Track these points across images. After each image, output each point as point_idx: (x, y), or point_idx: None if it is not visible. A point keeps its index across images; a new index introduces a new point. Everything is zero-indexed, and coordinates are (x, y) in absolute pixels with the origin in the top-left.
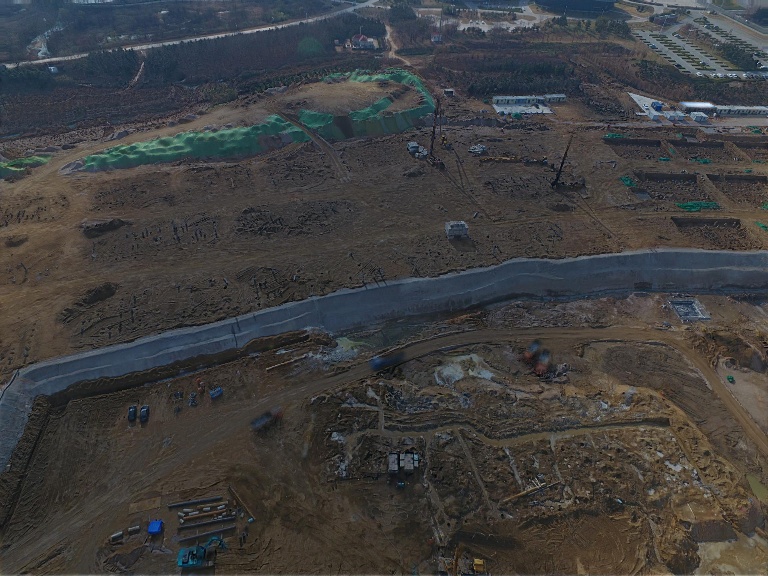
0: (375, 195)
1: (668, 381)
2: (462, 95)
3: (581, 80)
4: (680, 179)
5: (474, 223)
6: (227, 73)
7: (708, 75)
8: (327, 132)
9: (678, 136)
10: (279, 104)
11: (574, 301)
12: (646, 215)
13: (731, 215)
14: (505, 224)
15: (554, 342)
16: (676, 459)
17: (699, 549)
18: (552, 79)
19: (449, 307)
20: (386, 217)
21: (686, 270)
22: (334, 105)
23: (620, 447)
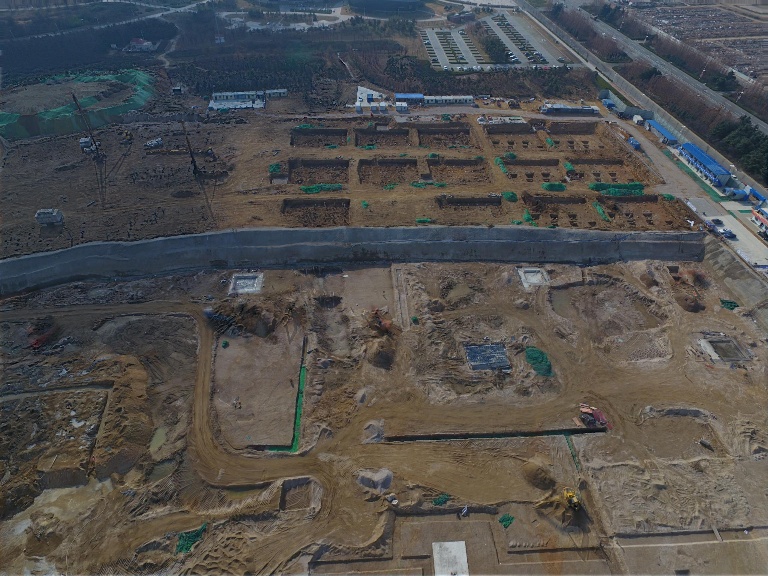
0: (7, 188)
1: (159, 348)
2: (191, 93)
3: (323, 76)
4: (335, 165)
5: (82, 211)
6: None
7: (455, 68)
8: (9, 131)
9: (367, 125)
10: None
11: (136, 280)
12: (261, 198)
13: (345, 195)
14: (113, 211)
15: (78, 318)
16: (85, 416)
17: (40, 495)
18: (284, 75)
19: (1, 290)
20: None
21: (261, 247)
22: (31, 105)
23: (36, 408)
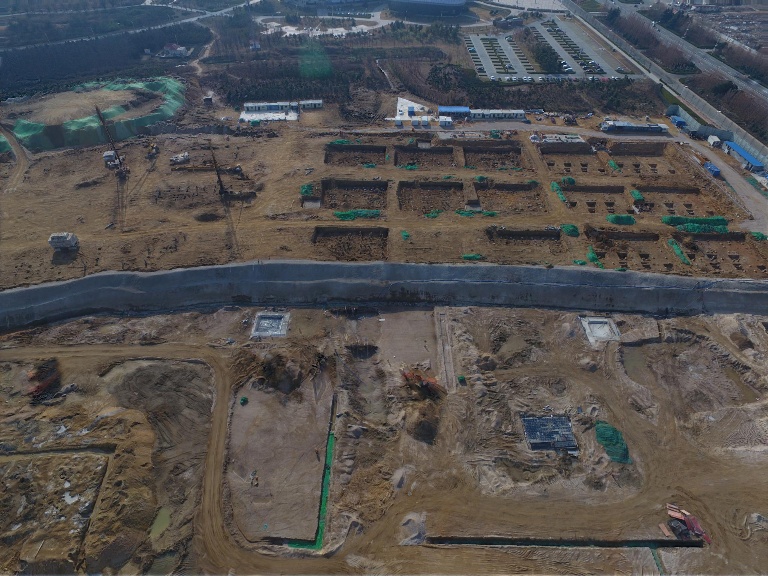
0: (25, 206)
1: (170, 403)
2: (222, 102)
3: (361, 85)
4: (372, 186)
5: (99, 234)
6: (5, 84)
7: (503, 78)
8: (34, 142)
9: (408, 142)
10: (4, 114)
11: (151, 316)
12: (290, 224)
13: (383, 224)
14: (132, 235)
15: (84, 360)
16: (80, 490)
17: None
18: (319, 85)
19: (6, 323)
20: (13, 229)
21: (289, 282)
22: (58, 114)
23: (27, 476)
